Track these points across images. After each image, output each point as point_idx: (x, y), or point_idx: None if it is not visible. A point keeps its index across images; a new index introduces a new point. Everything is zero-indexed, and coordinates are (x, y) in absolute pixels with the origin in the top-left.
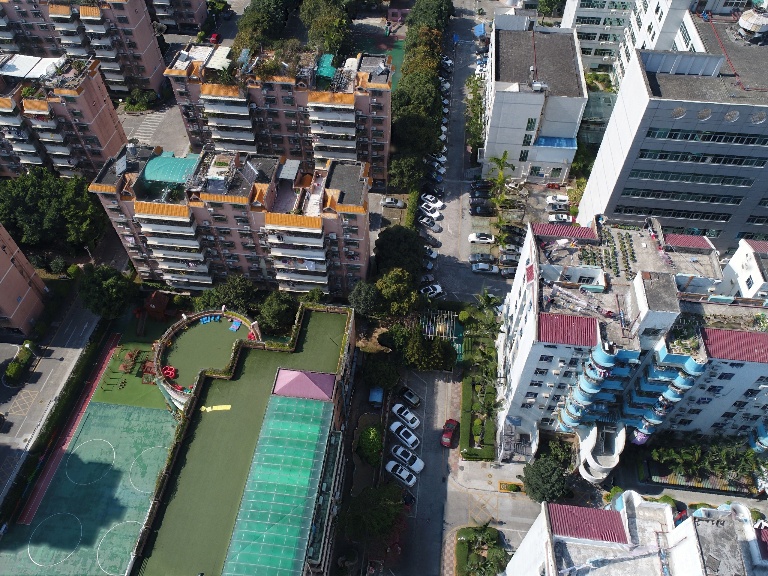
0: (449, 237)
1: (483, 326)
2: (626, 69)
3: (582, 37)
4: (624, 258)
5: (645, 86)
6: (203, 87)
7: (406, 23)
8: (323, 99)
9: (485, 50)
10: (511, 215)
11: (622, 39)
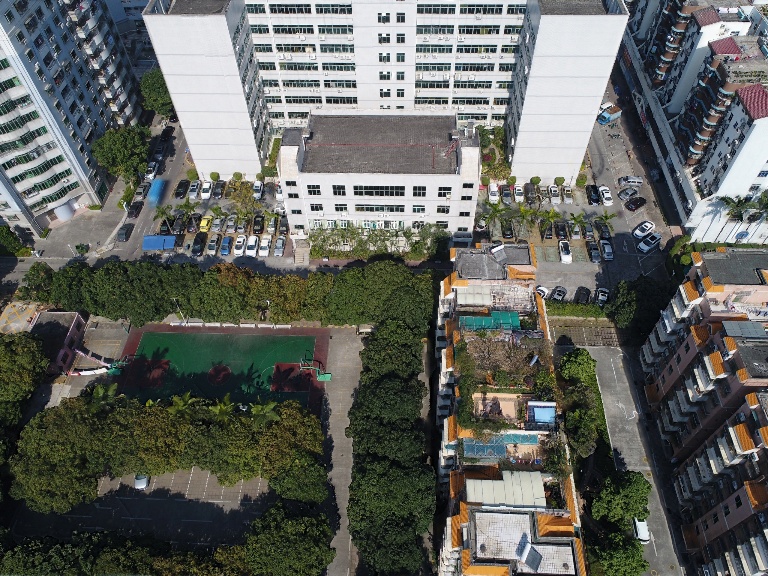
0: (568, 281)
1: (764, 210)
2: (358, 95)
3: (257, 129)
4: (765, 76)
5: (608, 16)
6: (571, 517)
7: (147, 321)
8: (545, 331)
9: (201, 243)
10: (520, 230)
11: (265, 101)
